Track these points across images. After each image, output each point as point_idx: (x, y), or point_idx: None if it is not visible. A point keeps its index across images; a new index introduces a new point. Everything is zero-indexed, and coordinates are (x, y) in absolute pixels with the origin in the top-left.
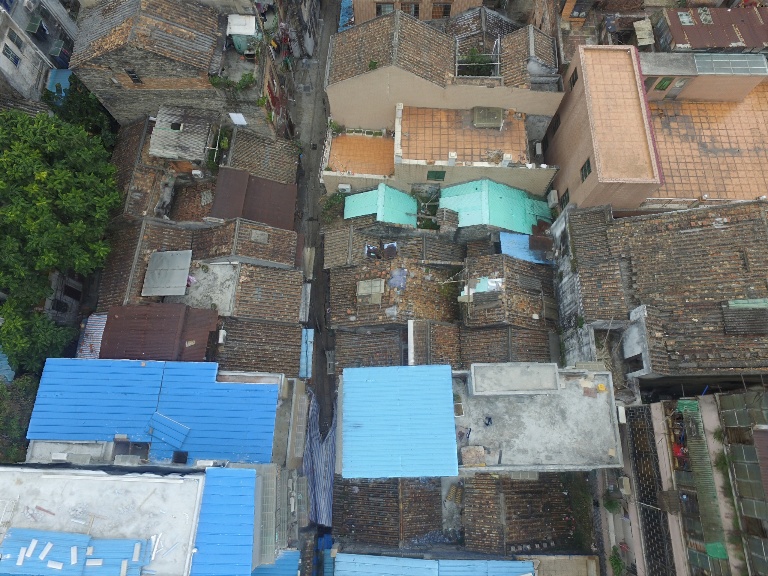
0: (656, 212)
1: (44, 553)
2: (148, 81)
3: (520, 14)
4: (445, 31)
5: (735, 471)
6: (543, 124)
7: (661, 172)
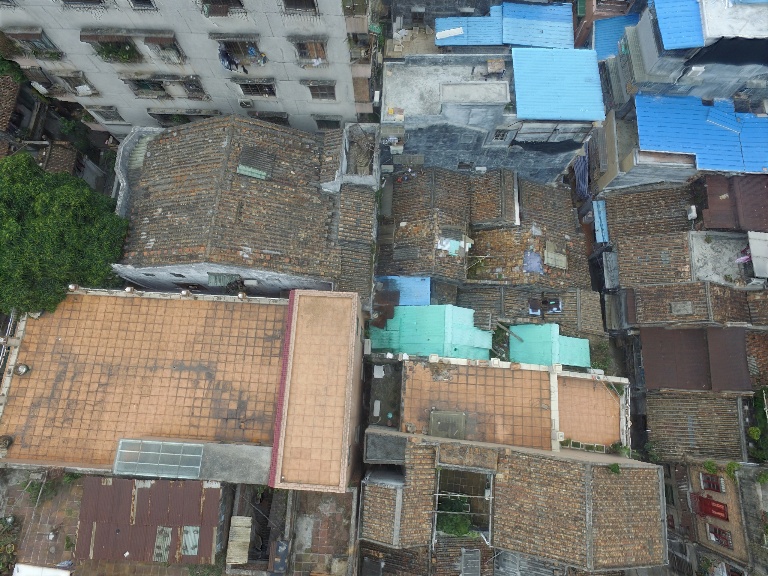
0: None
1: None
2: None
3: None
4: None
5: None
6: None
7: (266, 343)
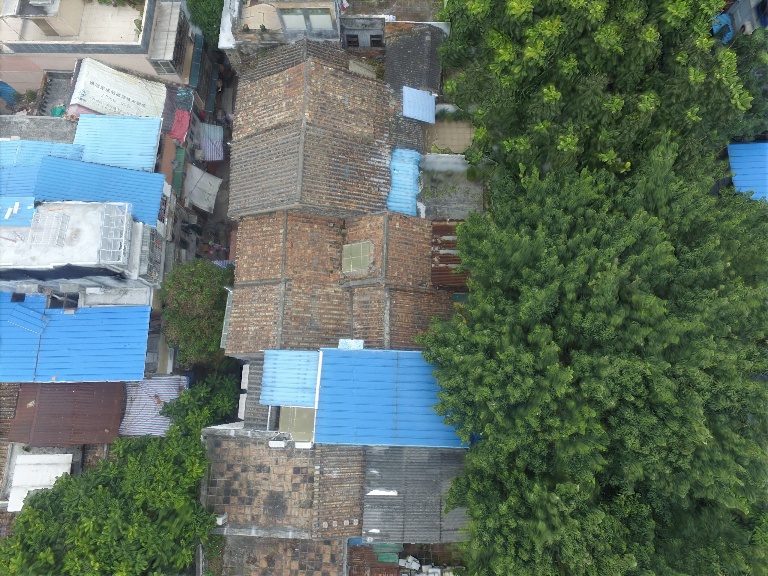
0: None
1: None
2: None
3: None
4: None
5: None
6: None
7: None
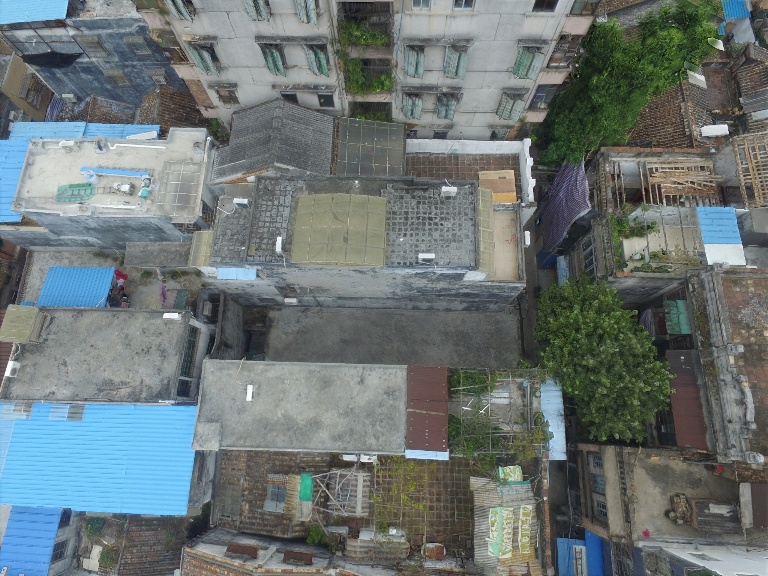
0: None
1: None
2: None
3: None
4: None
5: None
6: None
7: None
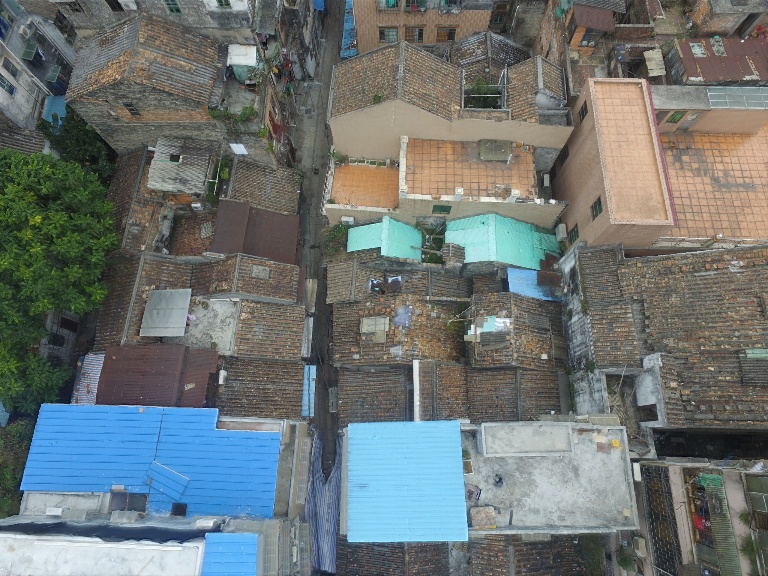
0: (668, 250)
1: None
2: (146, 113)
3: (526, 38)
4: (450, 55)
5: (764, 559)
6: (551, 156)
7: None
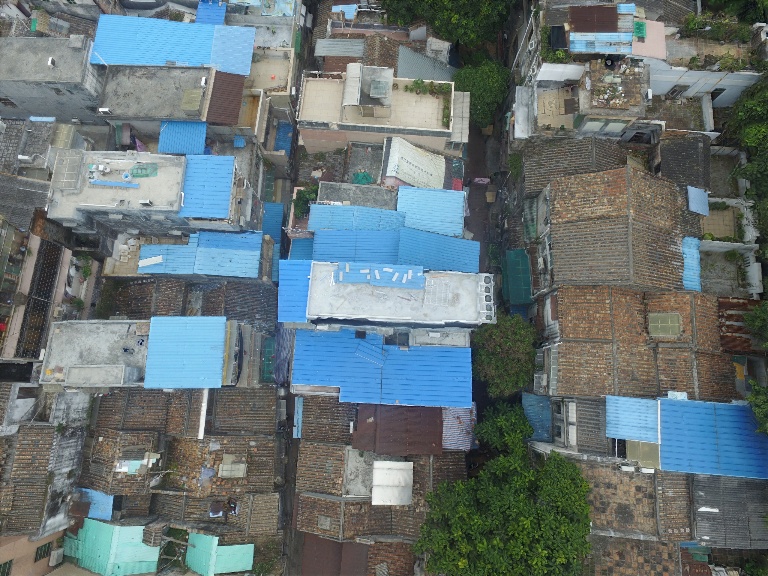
0: None
1: (396, 276)
2: None
3: None
4: None
5: None
6: None
7: None
